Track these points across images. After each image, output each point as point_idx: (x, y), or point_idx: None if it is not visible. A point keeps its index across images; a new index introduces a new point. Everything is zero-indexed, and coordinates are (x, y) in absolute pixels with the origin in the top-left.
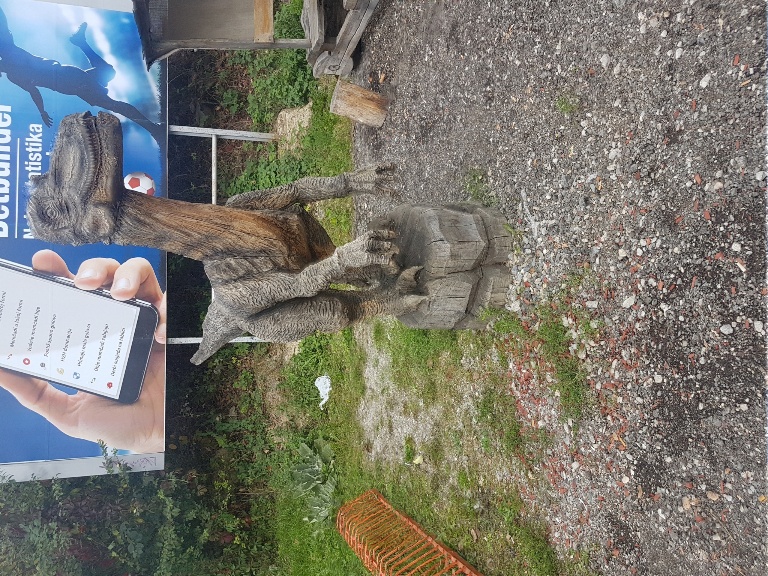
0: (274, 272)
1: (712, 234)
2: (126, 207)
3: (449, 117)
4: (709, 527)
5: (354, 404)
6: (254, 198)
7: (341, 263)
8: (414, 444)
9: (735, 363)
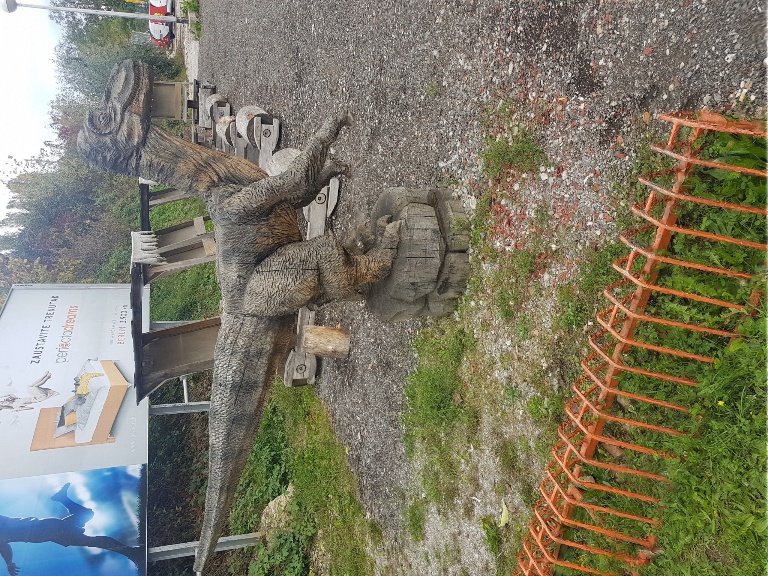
0: None
1: None
2: (155, 126)
3: None
4: (612, 6)
5: None
6: None
7: None
8: (491, 516)
9: None
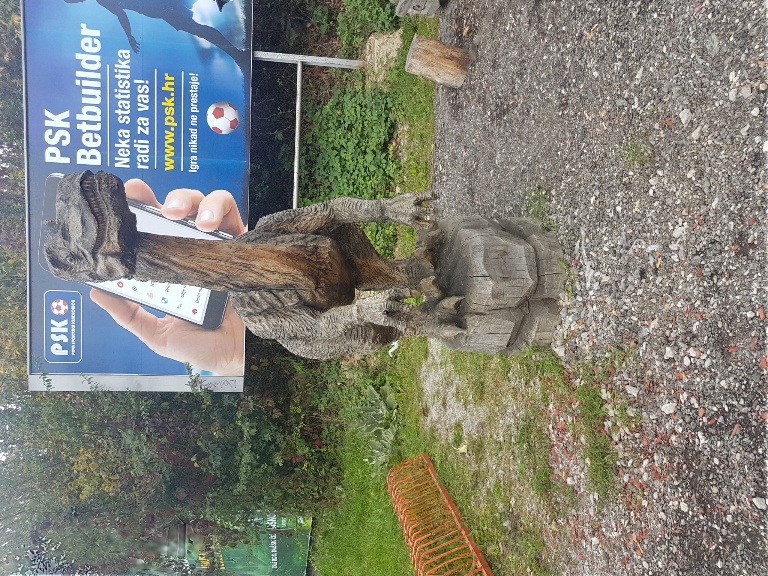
0: (299, 307)
1: (765, 387)
2: (143, 253)
3: (523, 107)
4: None
5: (417, 363)
6: (286, 221)
7: (360, 317)
8: (461, 431)
9: (762, 544)
